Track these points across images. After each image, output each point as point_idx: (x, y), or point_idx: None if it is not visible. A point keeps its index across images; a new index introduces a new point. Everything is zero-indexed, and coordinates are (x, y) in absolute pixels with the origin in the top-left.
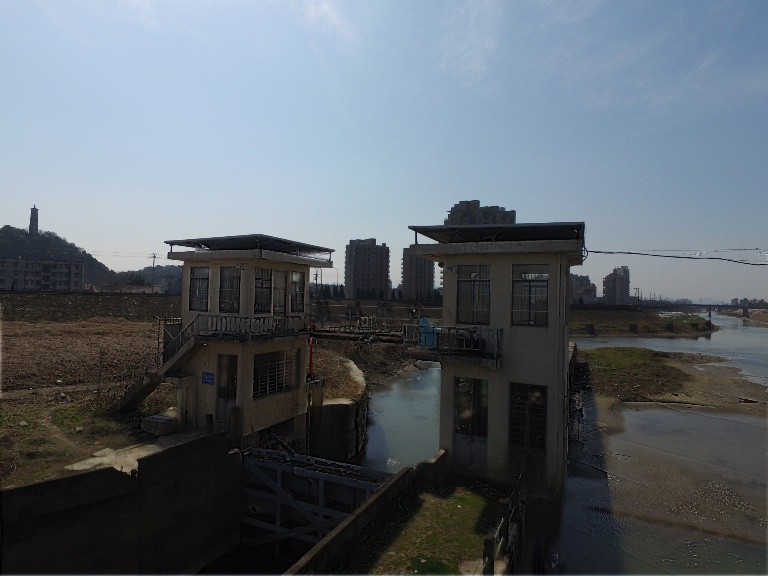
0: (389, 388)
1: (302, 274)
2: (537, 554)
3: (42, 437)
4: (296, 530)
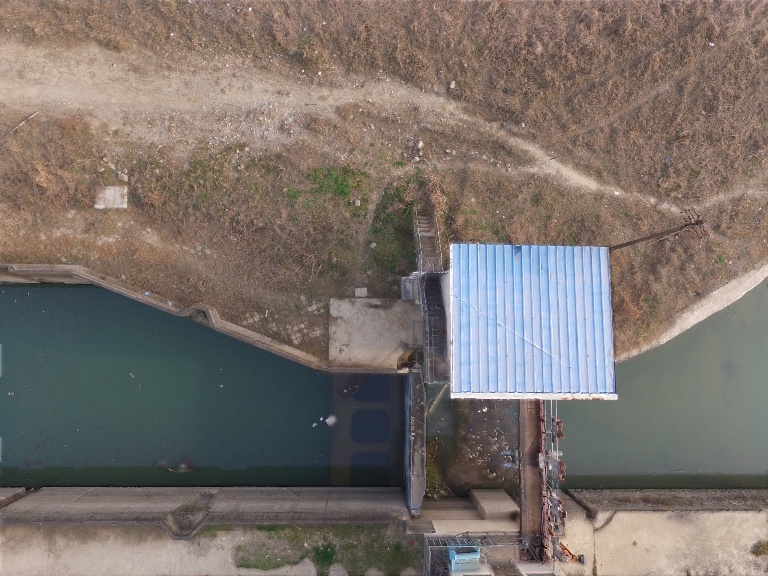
0: None
1: None
2: None
3: (353, 237)
4: (406, 413)
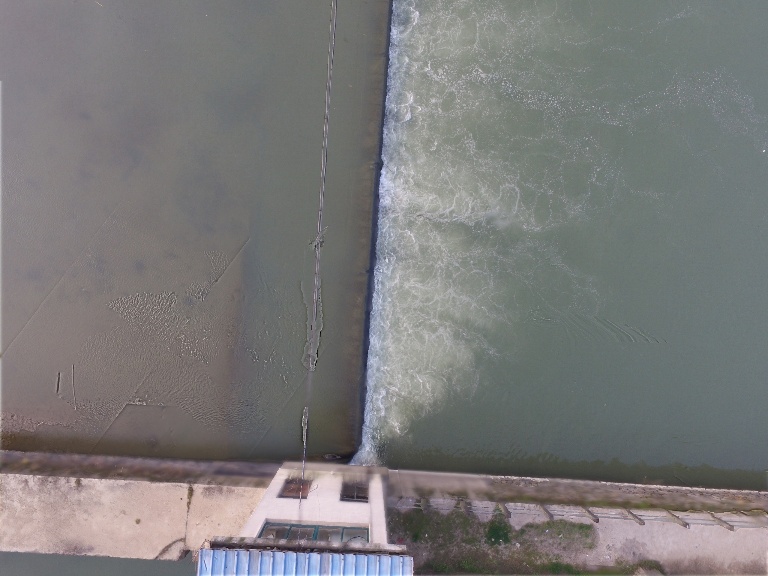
0: None
1: None
2: None
3: None
4: None
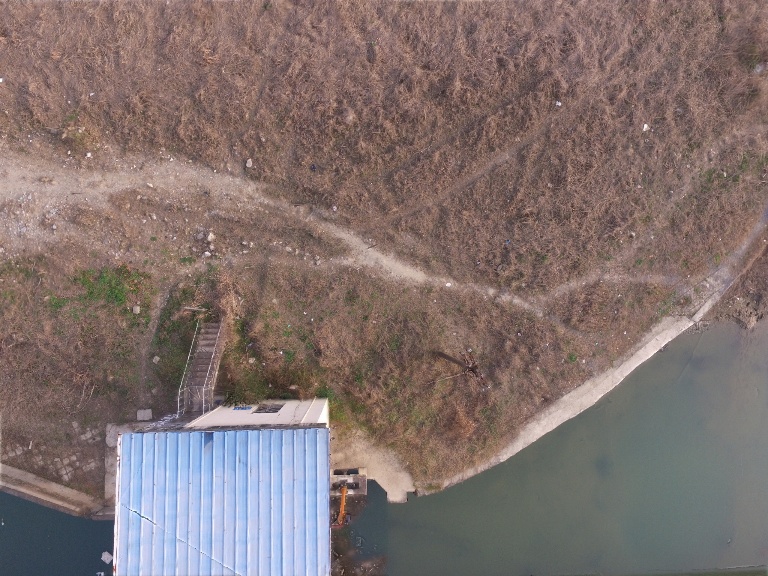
0: (740, 348)
1: None
2: None
3: (132, 349)
4: None
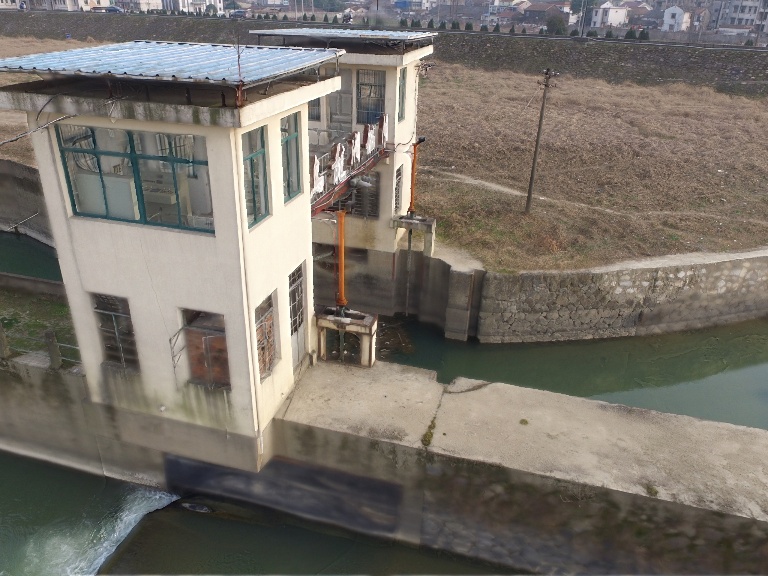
0: None
1: (381, 73)
2: (168, 469)
3: None
4: None
